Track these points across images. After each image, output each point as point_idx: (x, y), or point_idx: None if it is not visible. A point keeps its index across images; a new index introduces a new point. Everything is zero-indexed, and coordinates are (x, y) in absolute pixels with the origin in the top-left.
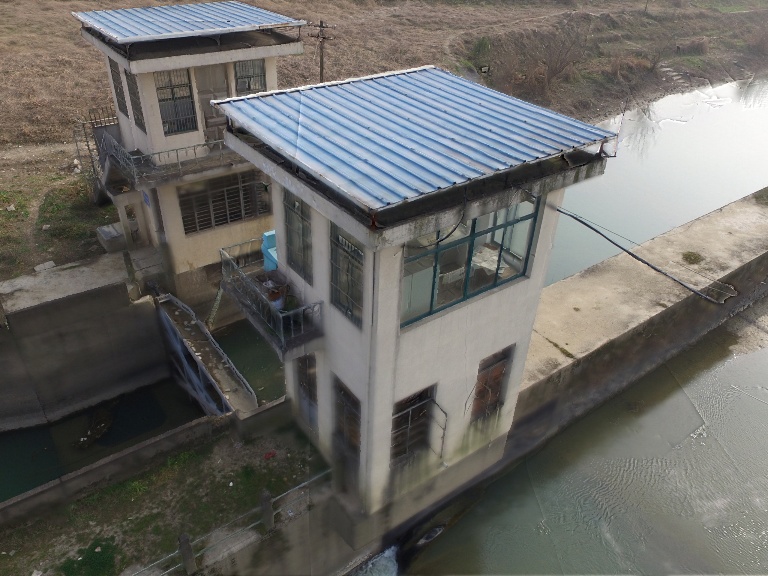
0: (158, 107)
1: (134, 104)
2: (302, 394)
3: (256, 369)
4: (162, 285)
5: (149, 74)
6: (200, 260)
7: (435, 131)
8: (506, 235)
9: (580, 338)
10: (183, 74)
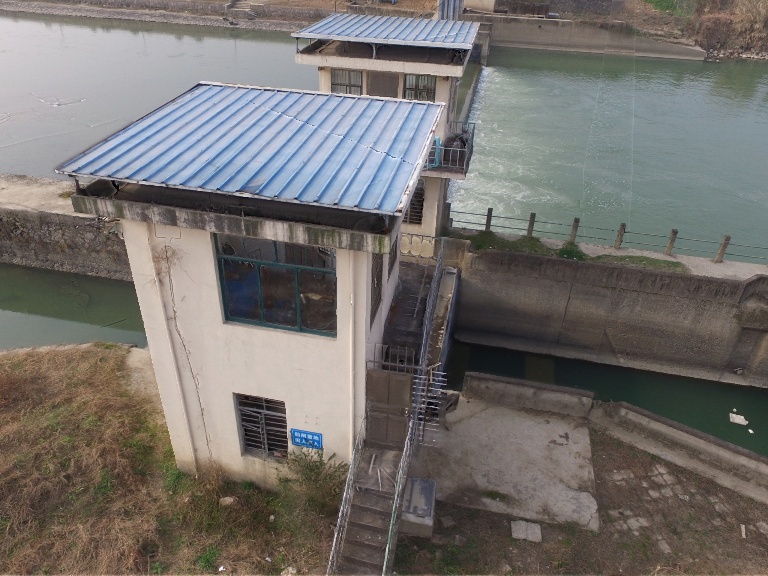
0: None
1: None
2: None
3: None
4: None
5: None
6: None
7: None
8: None
9: None
10: None
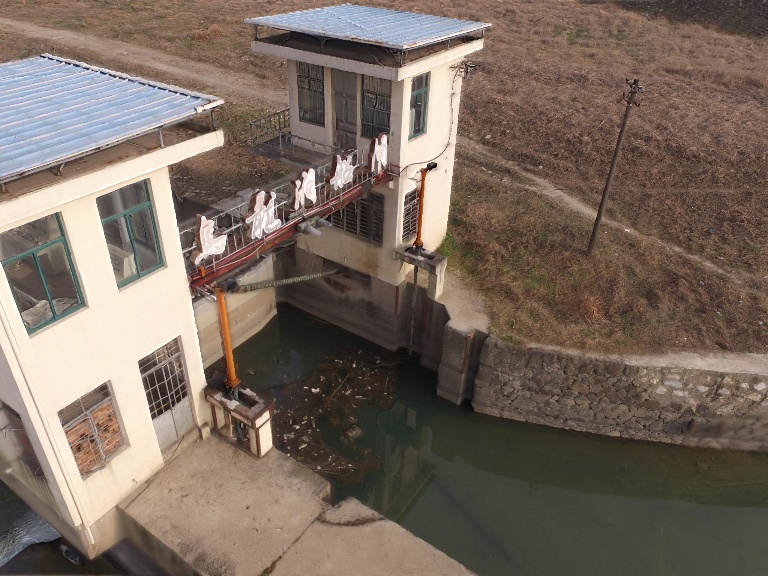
0: (298, 92)
1: None
2: None
3: (284, 363)
4: None
5: None
6: (316, 247)
7: None
8: (763, 540)
9: None
10: (319, 70)
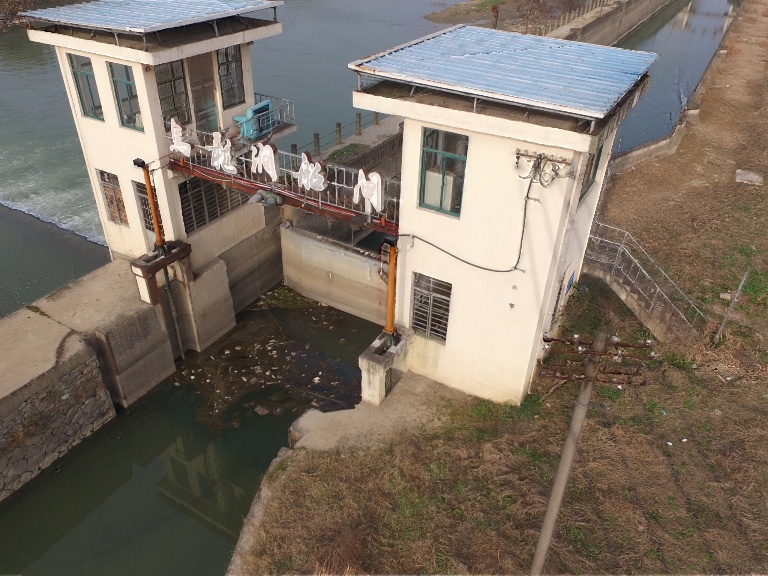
0: None
1: None
2: None
3: None
4: None
5: None
6: None
7: (140, 5)
8: None
9: (10, 327)
10: None
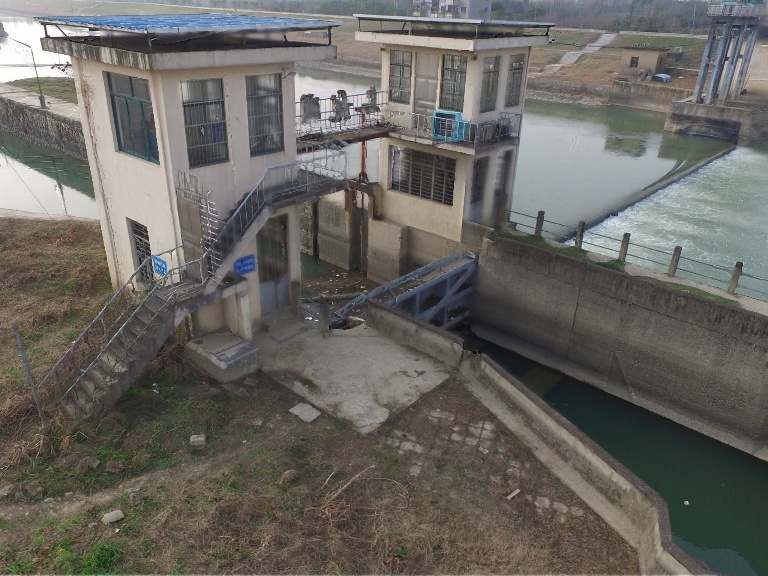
0: None
1: (259, 125)
2: (473, 205)
3: None
4: None
5: None
6: None
7: None
8: None
9: None
10: None
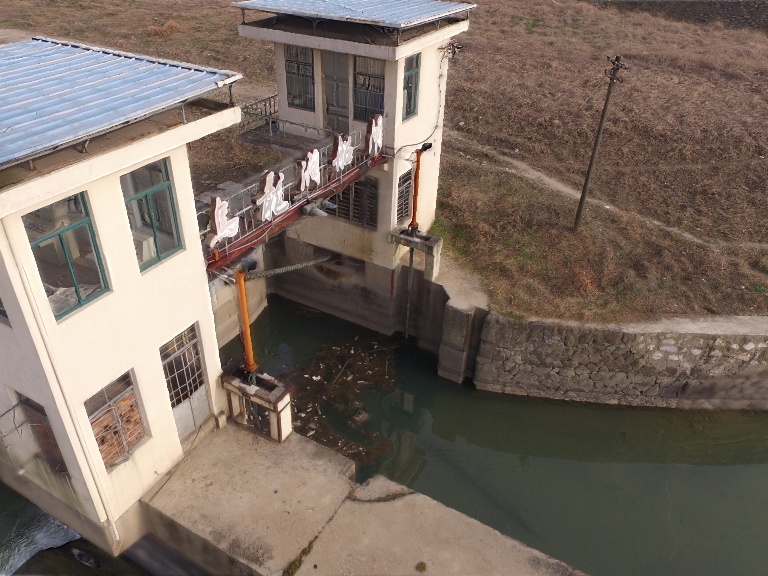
0: (286, 77)
1: None
2: None
3: None
4: (282, 240)
5: (282, 45)
6: (306, 235)
7: None
8: (761, 492)
9: None
10: (308, 53)
